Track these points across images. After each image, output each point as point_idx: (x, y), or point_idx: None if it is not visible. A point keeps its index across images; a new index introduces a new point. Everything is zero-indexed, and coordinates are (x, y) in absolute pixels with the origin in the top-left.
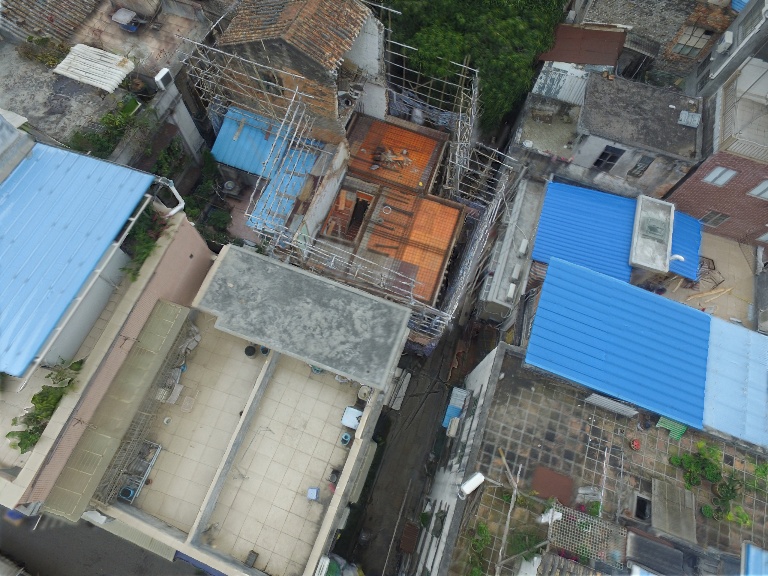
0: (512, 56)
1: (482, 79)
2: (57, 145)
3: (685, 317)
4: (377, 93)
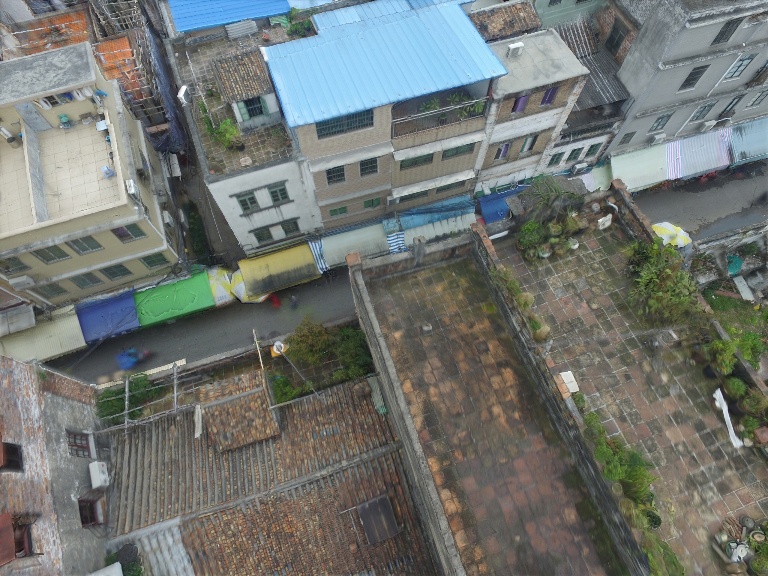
0: None
1: None
2: None
3: None
4: None
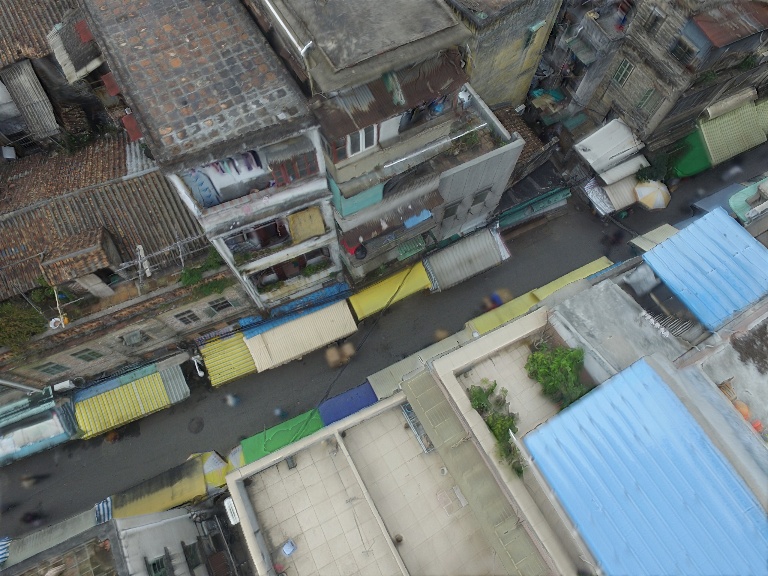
0: None
1: None
2: None
3: None
4: None
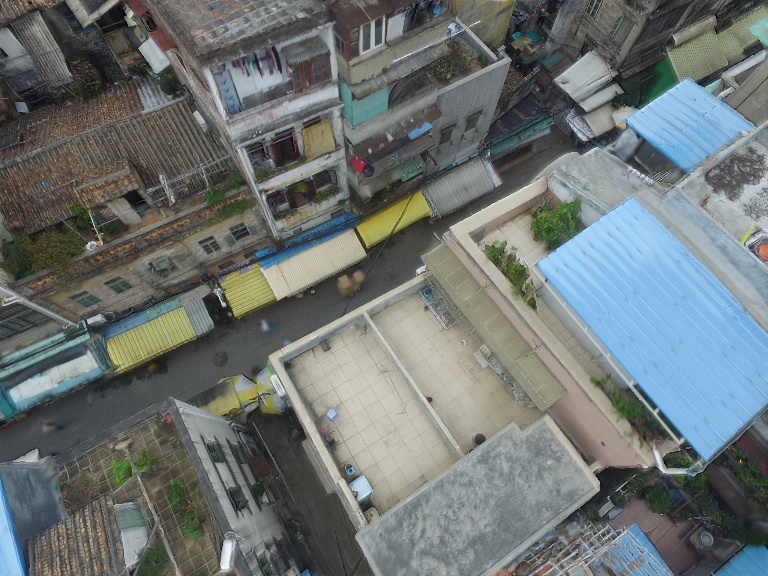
0: None
1: None
2: None
3: None
4: None
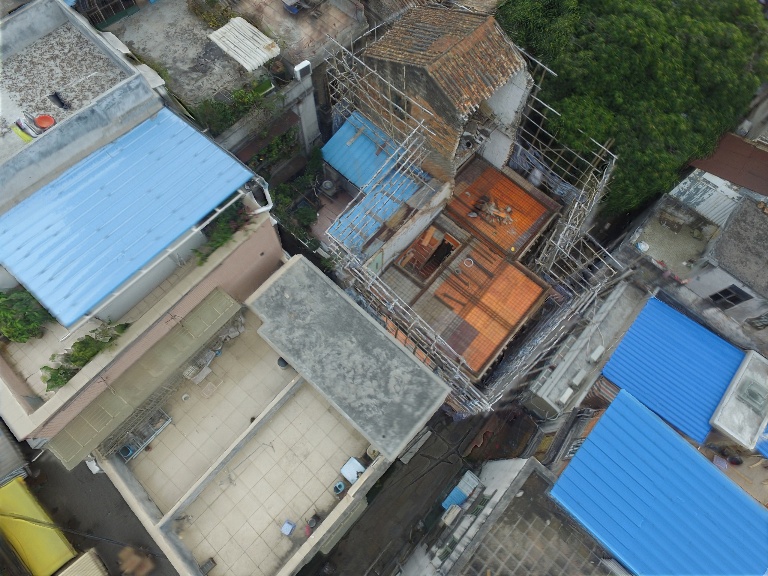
0: (661, 155)
1: (618, 167)
2: (181, 115)
3: (754, 517)
4: (503, 142)
